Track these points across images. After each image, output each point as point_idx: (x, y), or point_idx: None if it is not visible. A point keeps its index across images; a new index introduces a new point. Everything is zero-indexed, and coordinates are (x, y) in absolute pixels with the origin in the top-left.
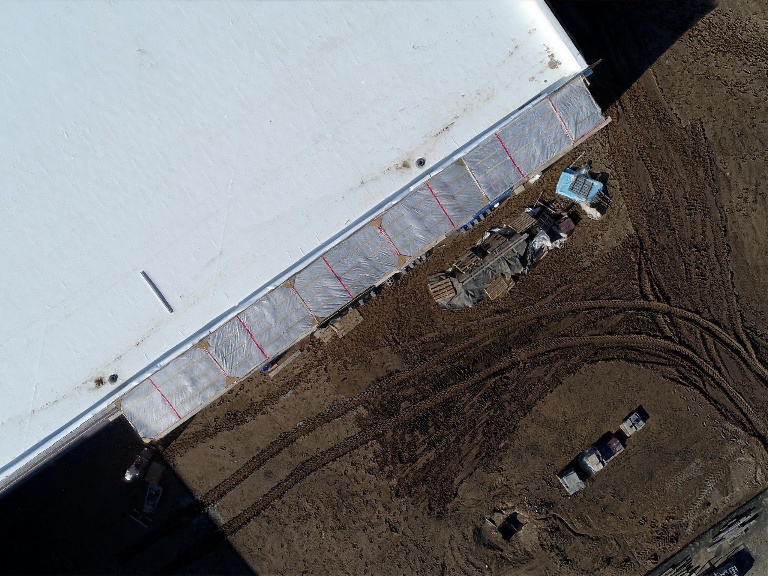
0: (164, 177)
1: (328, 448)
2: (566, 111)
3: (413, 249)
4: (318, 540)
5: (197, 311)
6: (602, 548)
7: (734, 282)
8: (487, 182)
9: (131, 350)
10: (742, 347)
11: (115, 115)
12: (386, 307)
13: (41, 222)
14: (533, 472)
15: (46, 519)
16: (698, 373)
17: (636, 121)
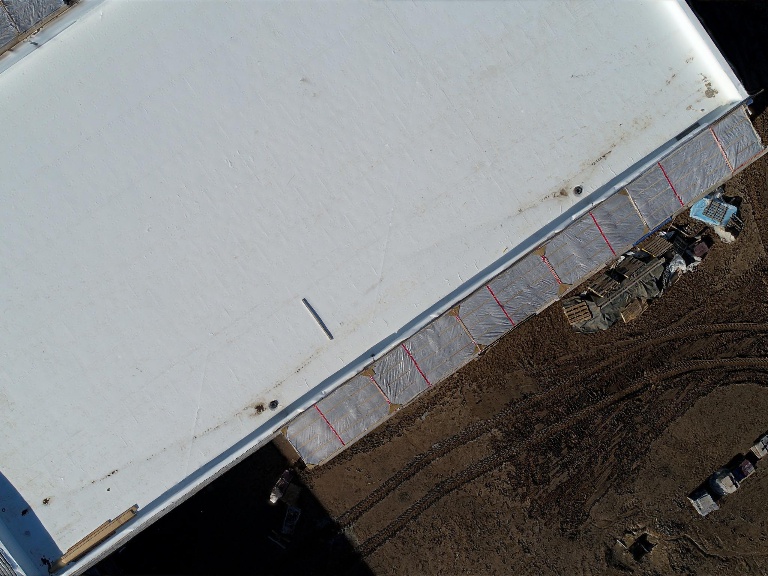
0: (326, 205)
1: (463, 470)
2: (727, 141)
3: (574, 277)
4: (452, 561)
5: (357, 338)
6: (732, 569)
7: None
8: (648, 211)
9: (292, 376)
10: None
11: (278, 144)
12: (521, 330)
13: (205, 250)
14: (664, 494)
15: (185, 540)
16: None
17: None
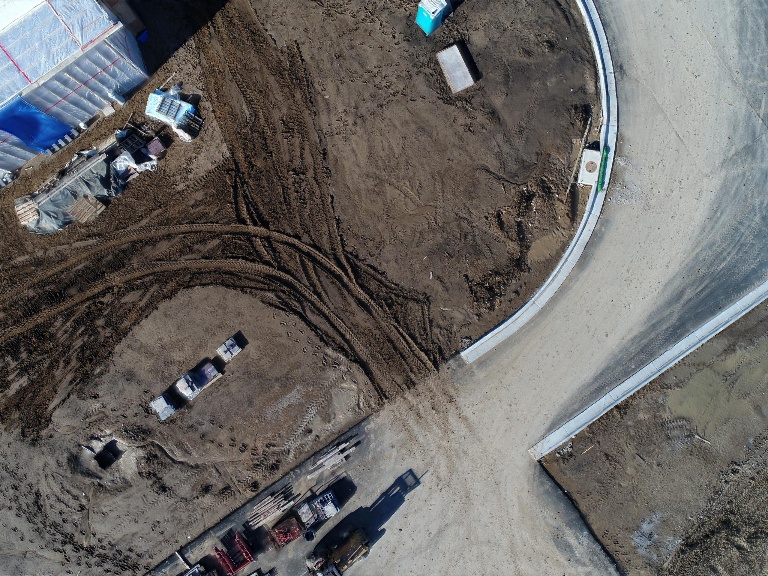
0: None
1: None
2: (69, 15)
3: None
4: None
5: None
6: (201, 476)
7: (334, 206)
8: None
9: None
10: (342, 272)
11: None
12: None
13: None
14: (130, 398)
15: None
16: (297, 298)
17: (229, 42)
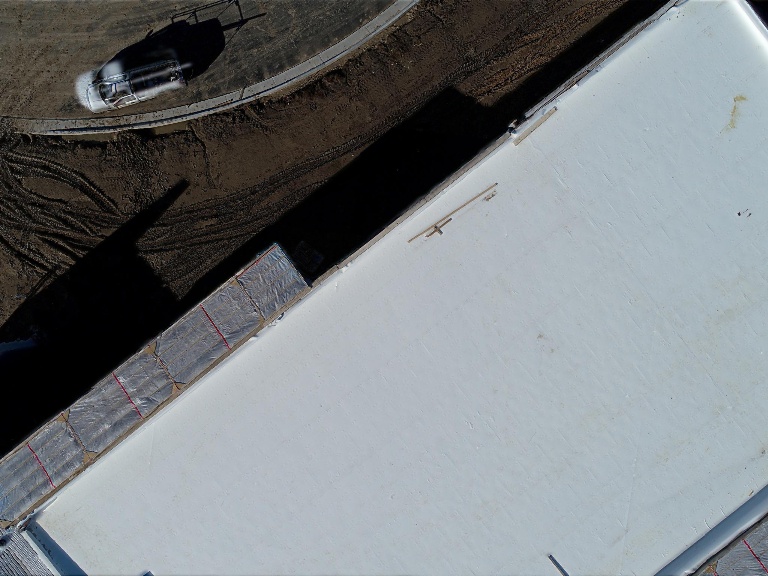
0: (568, 460)
1: None
2: None
3: None
4: None
5: None
6: None
7: None
8: None
9: None
10: None
11: (518, 402)
12: None
13: (449, 513)
14: None
15: None
16: None
17: None
